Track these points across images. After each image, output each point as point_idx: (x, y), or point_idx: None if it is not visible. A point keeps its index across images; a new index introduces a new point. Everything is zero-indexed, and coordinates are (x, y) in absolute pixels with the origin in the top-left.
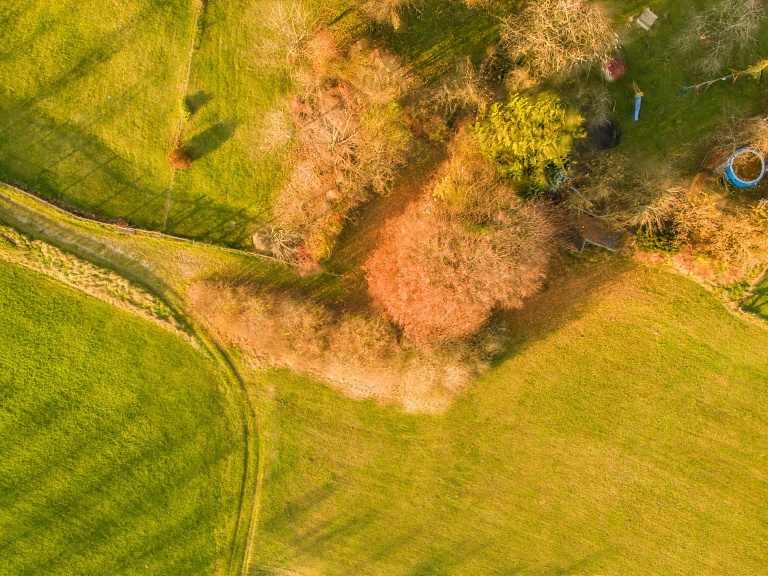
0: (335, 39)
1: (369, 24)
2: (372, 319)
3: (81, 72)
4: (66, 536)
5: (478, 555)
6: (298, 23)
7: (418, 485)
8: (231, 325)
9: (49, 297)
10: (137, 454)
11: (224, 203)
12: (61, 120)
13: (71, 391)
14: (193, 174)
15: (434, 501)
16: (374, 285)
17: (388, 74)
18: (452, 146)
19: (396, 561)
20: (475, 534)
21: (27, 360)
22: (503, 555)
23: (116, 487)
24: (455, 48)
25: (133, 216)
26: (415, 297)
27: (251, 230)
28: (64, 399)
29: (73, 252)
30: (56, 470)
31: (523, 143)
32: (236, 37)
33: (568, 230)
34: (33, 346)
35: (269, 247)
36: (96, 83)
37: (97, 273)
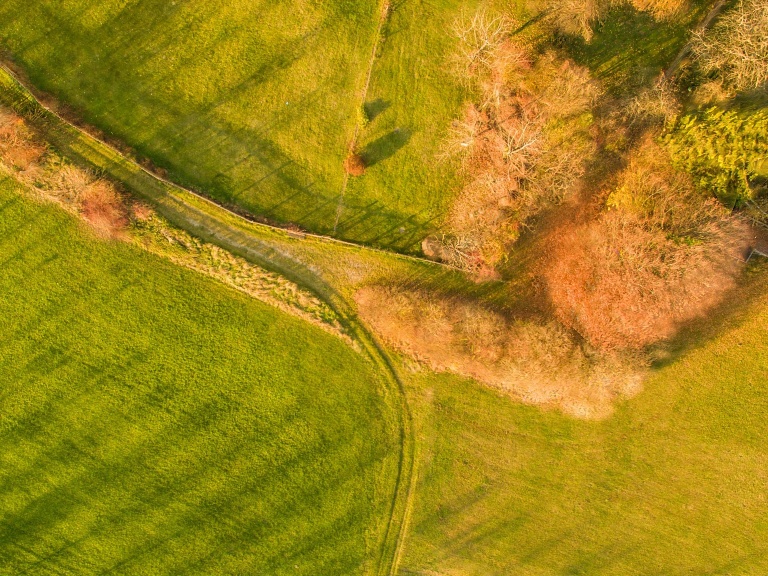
0: (517, 49)
1: (551, 35)
2: (553, 326)
3: (260, 78)
4: (218, 536)
5: (624, 558)
6: (480, 33)
7: (569, 489)
8: (396, 329)
9: (214, 300)
10: (293, 456)
11: (395, 209)
12: (238, 125)
13: (231, 393)
14: (366, 180)
15: (584, 505)
16: (541, 292)
17: (582, 85)
18: (634, 157)
19: (544, 564)
20: (623, 538)
21: (189, 362)
22: (649, 559)
23: (271, 488)
24: (634, 60)
25: (304, 221)
26: (583, 304)
27: (420, 236)
28: (224, 401)
29: (243, 256)
30: (212, 471)
31: (732, 156)
32: (418, 46)
33: (739, 240)
34: (196, 348)
35: (438, 253)
36: (275, 89)
37: (265, 277)
